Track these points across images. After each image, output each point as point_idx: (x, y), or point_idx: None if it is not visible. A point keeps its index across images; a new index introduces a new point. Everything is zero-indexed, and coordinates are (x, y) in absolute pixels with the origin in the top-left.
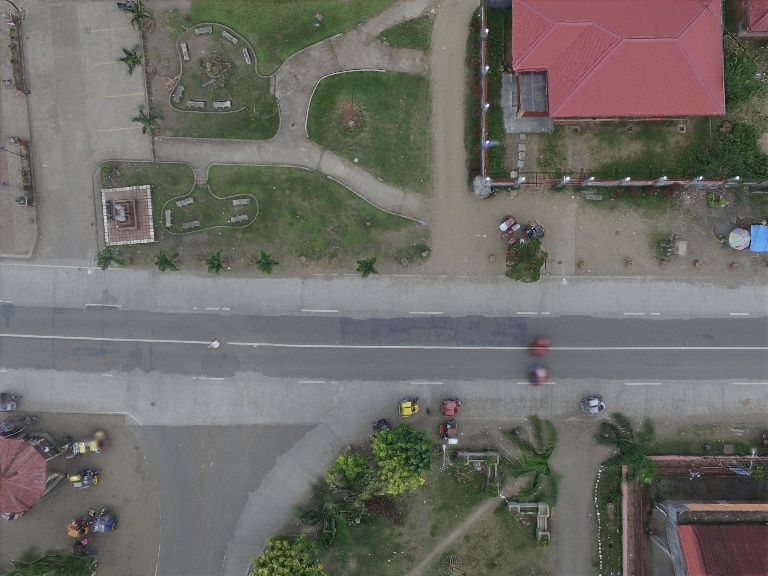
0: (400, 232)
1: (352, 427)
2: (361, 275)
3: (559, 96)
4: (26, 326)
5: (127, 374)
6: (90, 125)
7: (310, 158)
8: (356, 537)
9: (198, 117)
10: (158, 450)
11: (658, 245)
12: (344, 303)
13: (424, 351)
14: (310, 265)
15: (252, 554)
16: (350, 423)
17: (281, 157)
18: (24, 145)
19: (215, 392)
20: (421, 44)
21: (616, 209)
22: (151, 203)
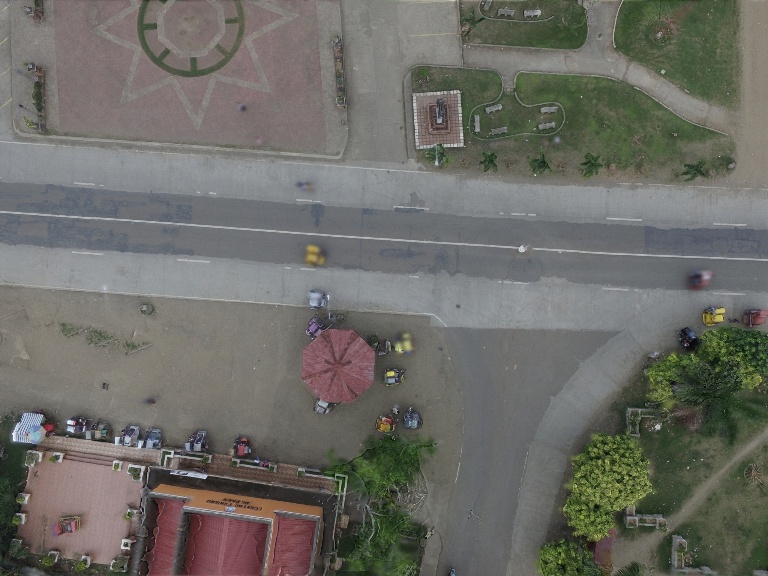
0: (705, 144)
1: (654, 335)
2: (685, 180)
3: None
4: (335, 226)
5: (433, 276)
6: (401, 30)
7: (616, 69)
8: (655, 444)
9: (507, 25)
10: (462, 352)
11: None
12: (648, 212)
13: (727, 262)
14: (616, 174)
15: (553, 457)
16: (652, 331)
17: (587, 67)
18: (340, 47)
19: (520, 296)
20: None
21: None
22: (461, 108)
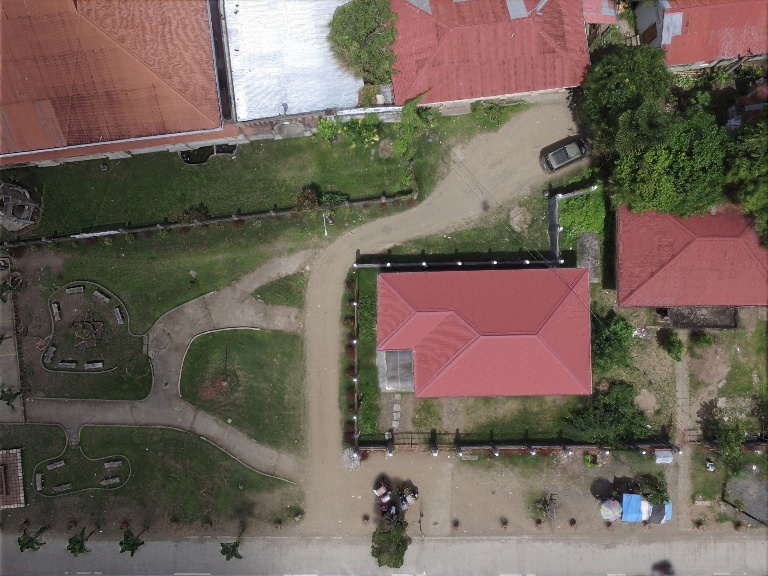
0: (274, 494)
1: None
2: None
3: (423, 380)
4: None
5: None
6: None
7: (183, 418)
8: None
9: (70, 377)
10: None
11: (534, 505)
12: (217, 566)
13: None
14: (183, 528)
15: None
16: None
17: (154, 417)
18: None
19: None
20: (296, 301)
21: (492, 468)
22: (21, 467)
